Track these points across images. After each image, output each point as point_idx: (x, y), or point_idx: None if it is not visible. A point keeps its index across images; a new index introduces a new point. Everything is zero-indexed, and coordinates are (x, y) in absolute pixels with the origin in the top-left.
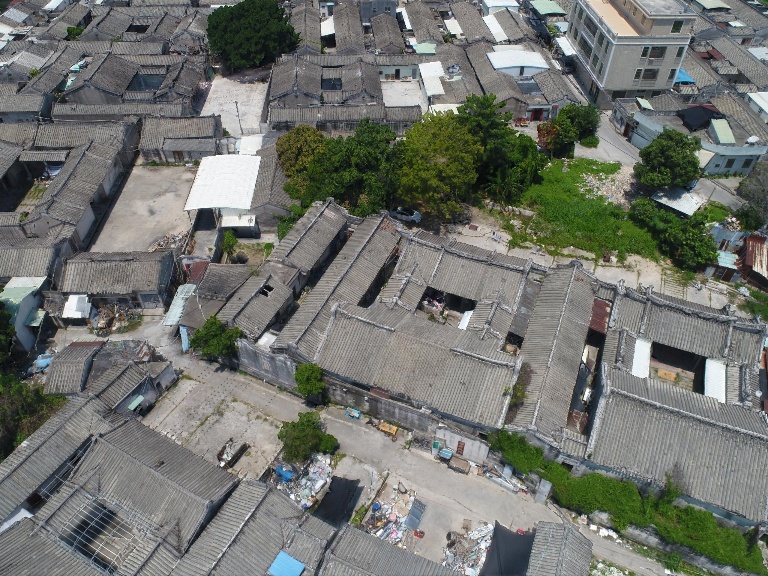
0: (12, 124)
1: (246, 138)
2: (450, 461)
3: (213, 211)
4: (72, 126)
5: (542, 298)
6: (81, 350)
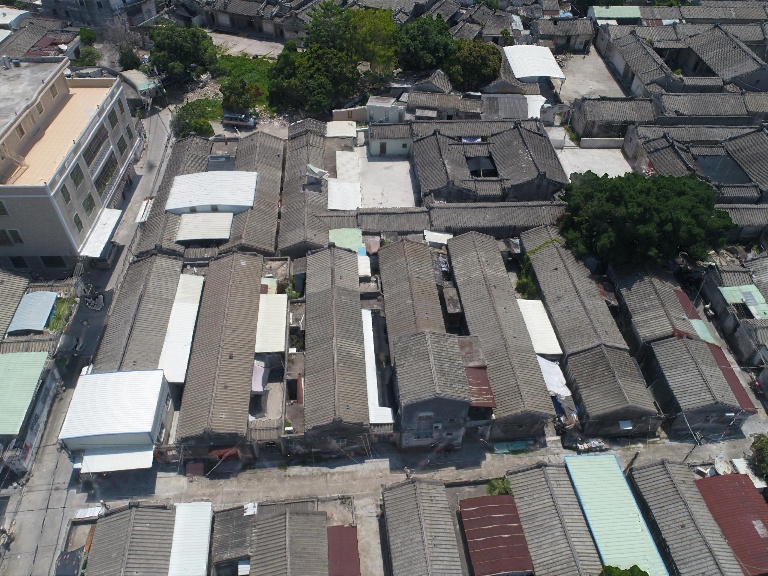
0: (766, 92)
1: (542, 99)
2: None
3: None
4: (710, 94)
5: None
6: (550, 7)
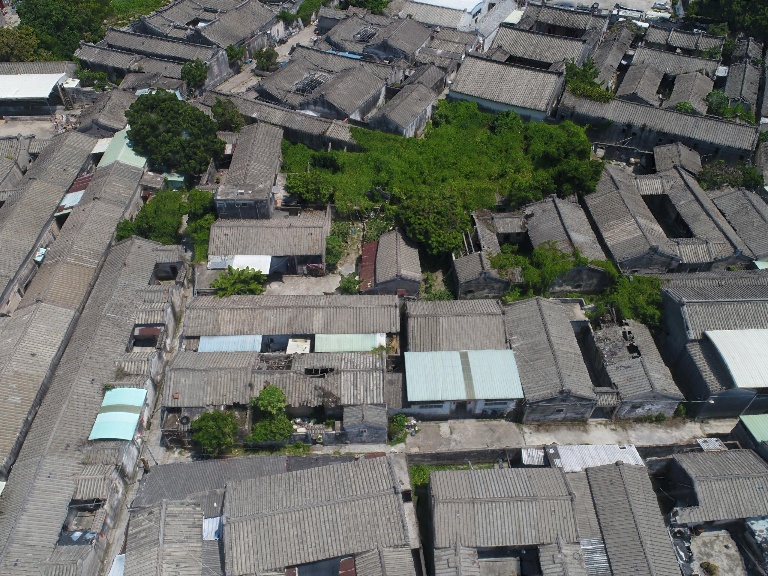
0: None
1: None
2: (282, 41)
3: (57, 86)
4: None
5: (202, 4)
6: None
